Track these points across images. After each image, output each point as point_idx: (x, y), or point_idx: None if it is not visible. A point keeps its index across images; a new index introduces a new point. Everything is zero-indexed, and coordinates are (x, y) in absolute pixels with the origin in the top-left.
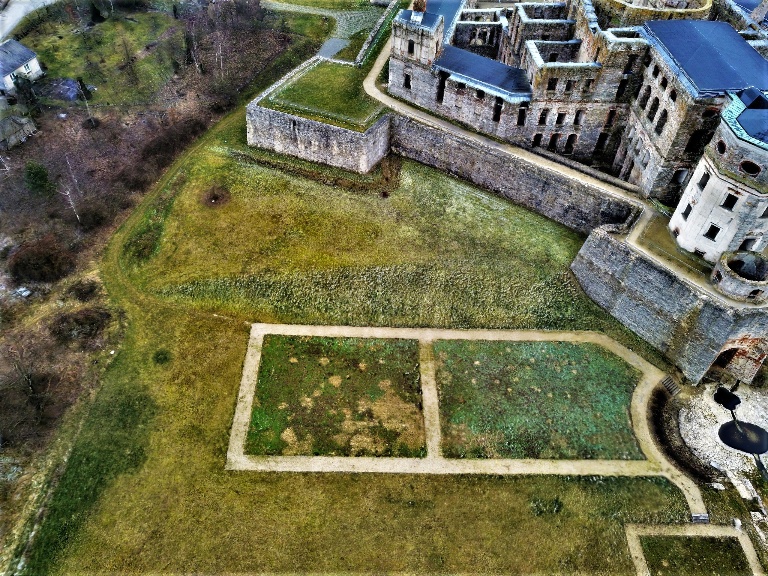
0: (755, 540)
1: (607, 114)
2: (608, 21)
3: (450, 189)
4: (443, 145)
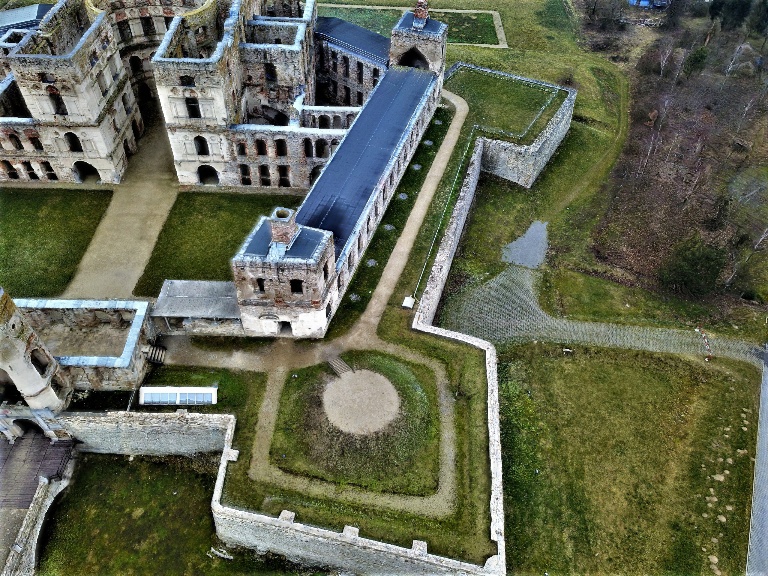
0: None
1: None
2: None
3: None
4: None
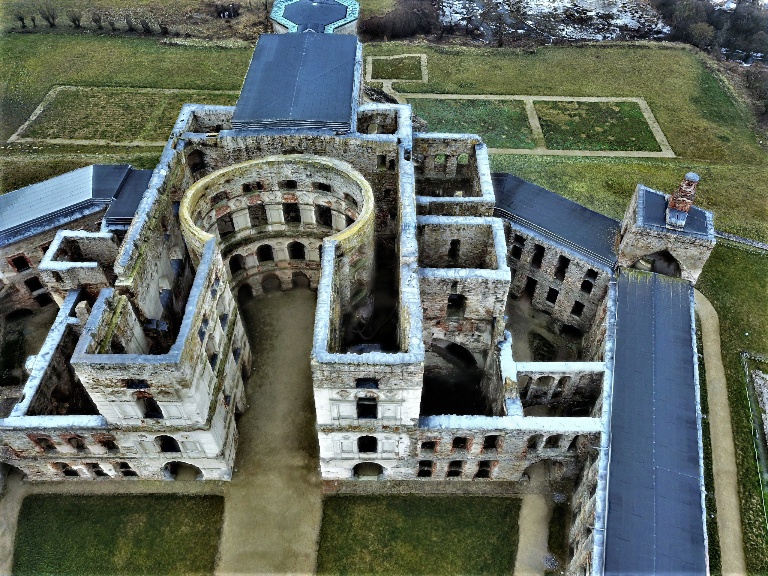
0: (364, 78)
1: None
2: None
3: None
4: None
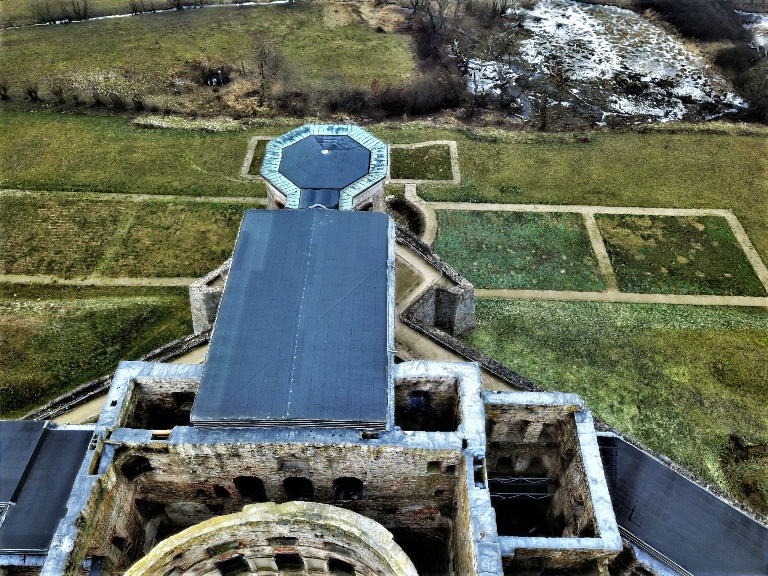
0: None
1: None
2: None
3: None
4: None
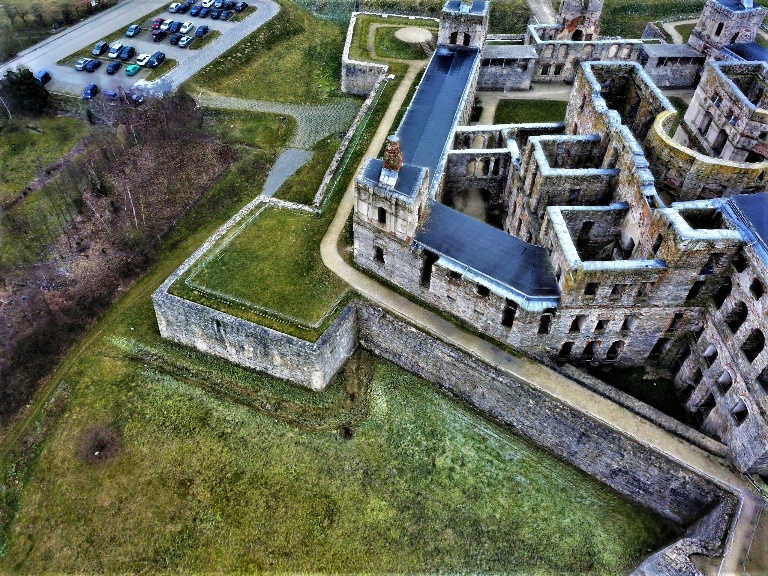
0: None
1: (670, 318)
2: (665, 172)
3: (442, 419)
4: (431, 356)
